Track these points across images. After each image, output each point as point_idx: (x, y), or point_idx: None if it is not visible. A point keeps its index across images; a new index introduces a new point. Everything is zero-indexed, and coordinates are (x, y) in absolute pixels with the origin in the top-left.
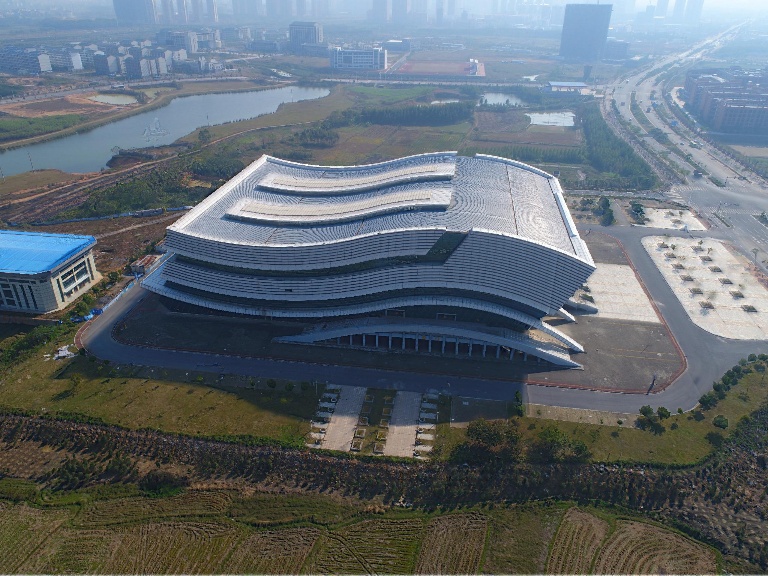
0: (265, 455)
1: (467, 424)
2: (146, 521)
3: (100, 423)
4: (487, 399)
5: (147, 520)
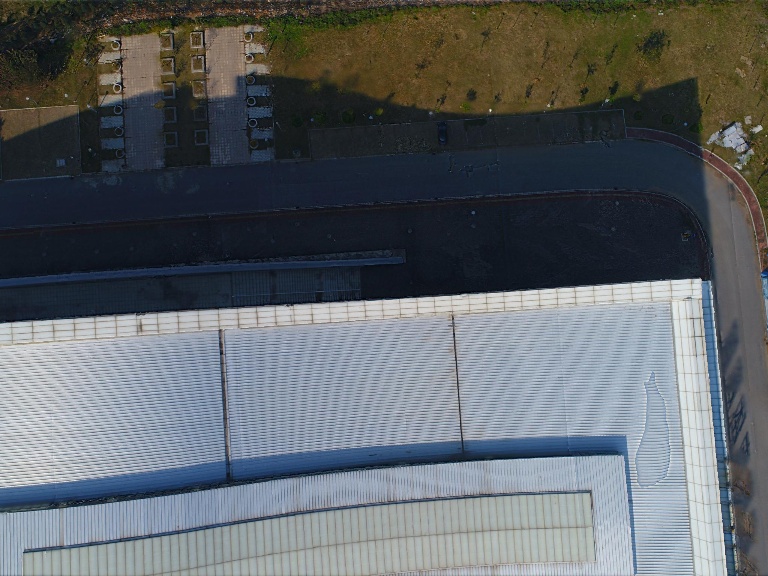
0: (313, 5)
1: (55, 116)
2: None
3: (560, 3)
4: (30, 179)
5: None
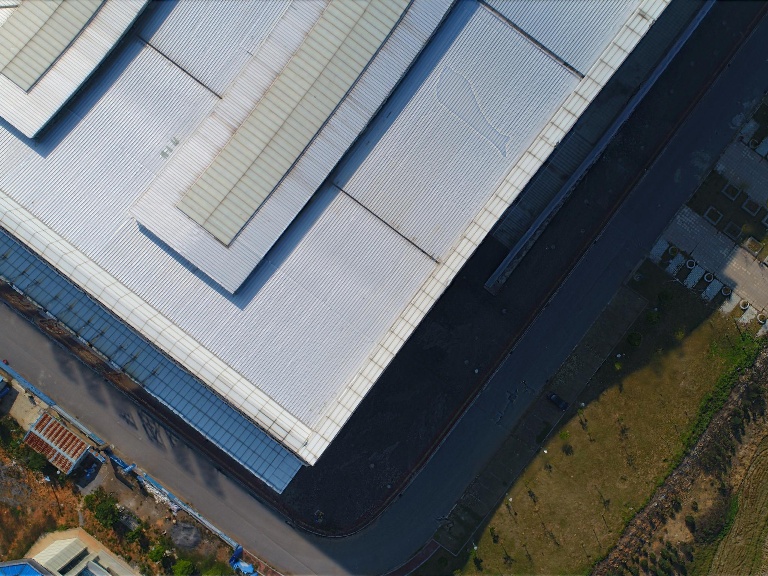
0: None
1: None
2: (761, 544)
3: None
4: None
5: (760, 543)
